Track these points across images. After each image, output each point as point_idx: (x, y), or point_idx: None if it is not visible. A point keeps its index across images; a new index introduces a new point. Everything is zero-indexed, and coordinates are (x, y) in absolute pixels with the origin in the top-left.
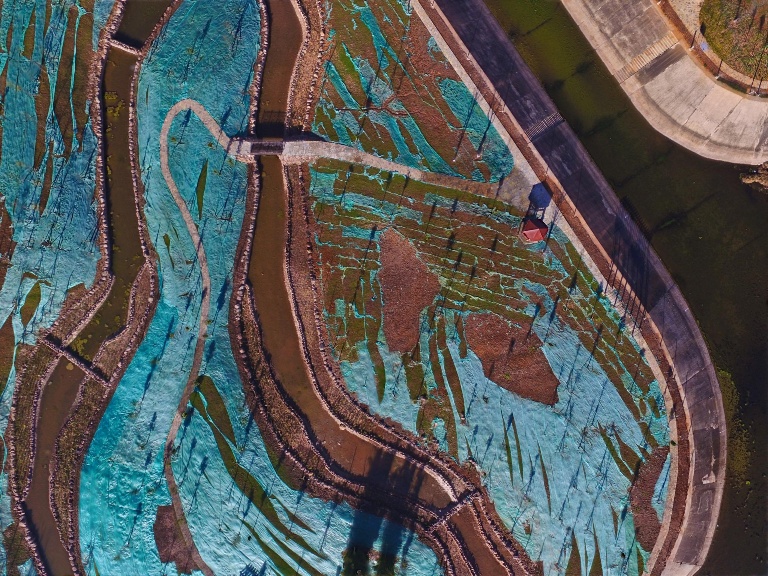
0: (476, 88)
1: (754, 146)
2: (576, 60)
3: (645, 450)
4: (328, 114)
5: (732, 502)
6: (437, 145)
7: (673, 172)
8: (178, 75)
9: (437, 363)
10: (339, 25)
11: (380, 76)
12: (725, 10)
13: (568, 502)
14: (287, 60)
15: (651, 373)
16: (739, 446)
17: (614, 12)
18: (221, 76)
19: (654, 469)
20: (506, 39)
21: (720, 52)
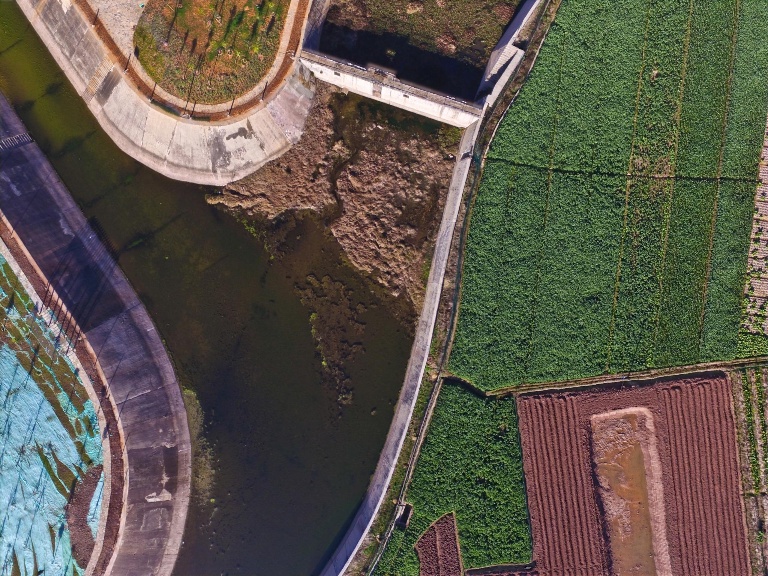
0: None
1: (209, 168)
2: (46, 81)
3: (80, 469)
4: None
5: (198, 519)
6: None
7: (141, 193)
8: None
9: None
10: None
11: None
12: (155, 34)
13: (8, 519)
14: None
15: (85, 393)
16: (204, 464)
17: (66, 34)
18: None
19: (89, 487)
20: None
21: (154, 75)
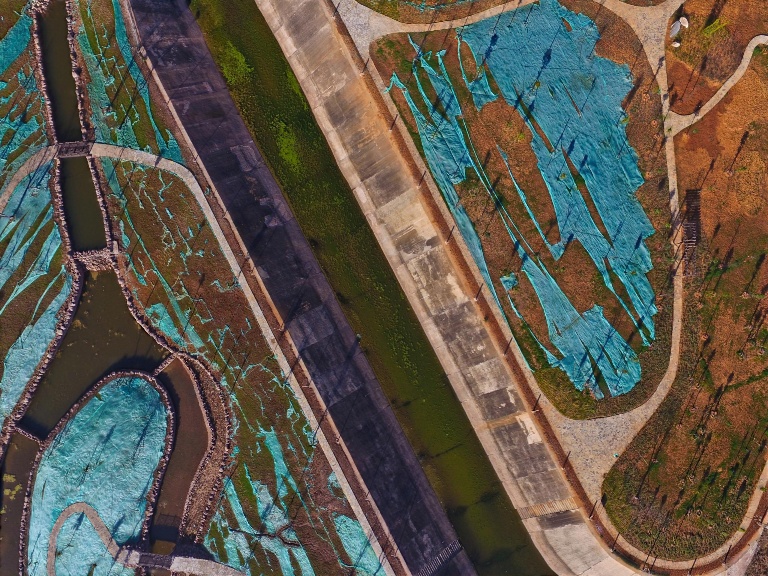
0: (371, 529)
1: None
2: (482, 489)
3: None
4: (221, 532)
5: None
6: None
7: None
8: (76, 477)
9: None
10: (243, 444)
11: (277, 504)
12: (627, 486)
13: None
14: (190, 465)
15: None
16: None
17: (521, 459)
18: (118, 483)
19: None
20: (414, 461)
21: (618, 525)
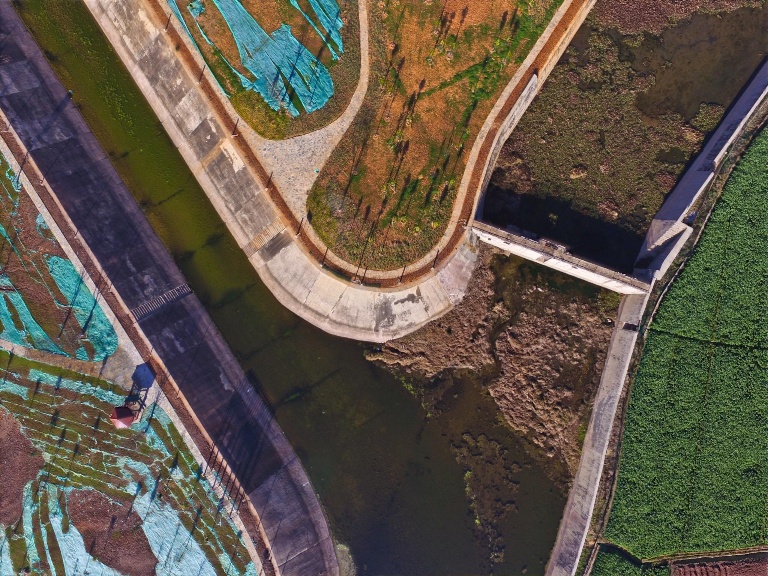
0: (83, 267)
1: (372, 327)
2: (206, 232)
3: None
4: None
5: None
6: (43, 322)
7: (299, 346)
8: None
9: (40, 537)
10: None
11: None
12: (330, 200)
13: None
14: None
15: (247, 555)
16: None
17: (233, 191)
18: None
19: None
20: (136, 209)
21: (326, 240)
